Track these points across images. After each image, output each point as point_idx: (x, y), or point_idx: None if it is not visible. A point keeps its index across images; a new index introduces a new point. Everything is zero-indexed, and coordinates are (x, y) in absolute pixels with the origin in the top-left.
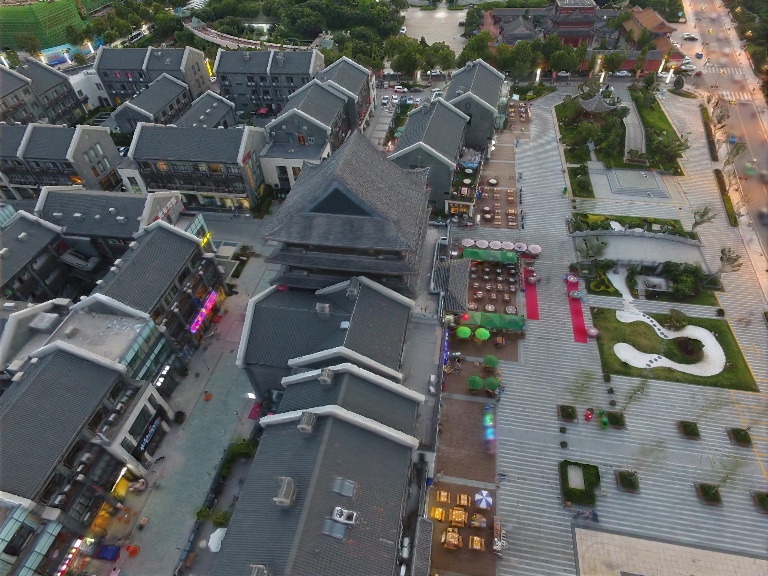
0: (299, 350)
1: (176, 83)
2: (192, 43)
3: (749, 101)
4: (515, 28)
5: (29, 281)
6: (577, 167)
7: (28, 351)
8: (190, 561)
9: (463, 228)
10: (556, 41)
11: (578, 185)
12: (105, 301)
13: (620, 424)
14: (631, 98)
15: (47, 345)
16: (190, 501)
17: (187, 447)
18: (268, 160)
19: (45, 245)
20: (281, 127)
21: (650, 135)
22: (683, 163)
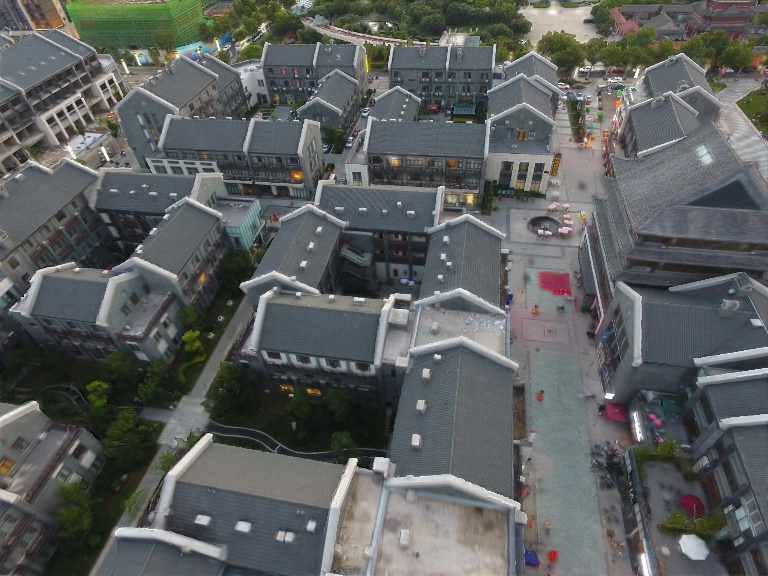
0: (702, 349)
1: (348, 79)
2: (315, 41)
3: None
4: (662, 24)
5: (327, 276)
6: None
7: (392, 347)
8: (664, 569)
9: None
10: (724, 36)
11: None
12: (469, 296)
13: None
14: None
15: (443, 341)
16: (584, 505)
17: (547, 448)
18: (496, 155)
19: (336, 240)
20: (504, 122)
21: None
22: None
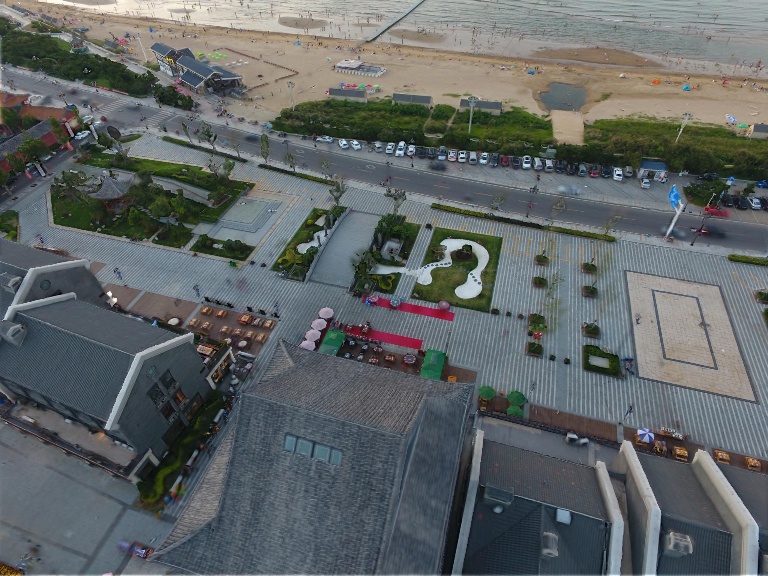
0: None
1: None
2: None
3: (174, 115)
4: None
5: None
6: (203, 241)
7: None
8: None
9: (250, 377)
10: None
11: (233, 250)
12: None
13: (543, 318)
14: (102, 168)
15: None
16: None
17: None
18: None
19: None
20: None
21: (192, 177)
22: (237, 178)
